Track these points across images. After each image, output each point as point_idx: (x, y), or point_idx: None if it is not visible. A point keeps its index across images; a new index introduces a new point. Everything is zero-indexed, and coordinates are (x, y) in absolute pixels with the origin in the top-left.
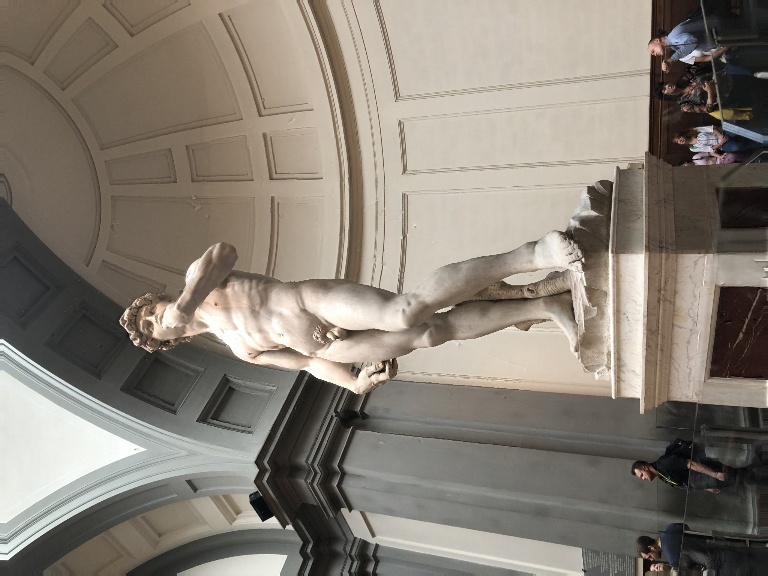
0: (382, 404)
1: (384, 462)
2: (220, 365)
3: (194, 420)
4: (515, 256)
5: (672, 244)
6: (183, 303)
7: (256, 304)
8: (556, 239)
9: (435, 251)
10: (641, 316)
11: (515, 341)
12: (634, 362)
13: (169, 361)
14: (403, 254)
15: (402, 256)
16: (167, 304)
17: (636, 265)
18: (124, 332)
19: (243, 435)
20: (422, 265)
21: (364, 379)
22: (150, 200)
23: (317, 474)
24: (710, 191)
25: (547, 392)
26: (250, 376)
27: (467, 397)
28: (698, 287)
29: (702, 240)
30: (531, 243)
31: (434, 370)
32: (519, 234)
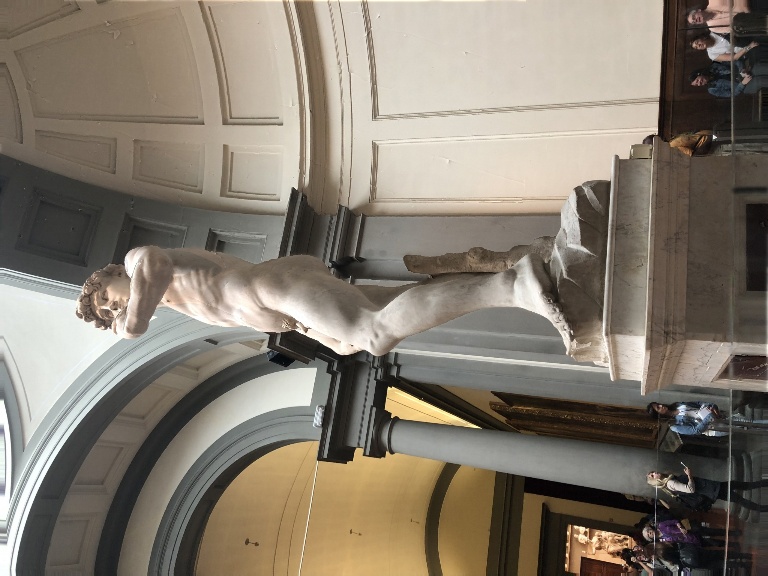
0: (377, 247)
1: None
2: (202, 219)
3: None
4: (491, 292)
5: (681, 322)
6: (131, 326)
7: (211, 301)
8: (538, 294)
9: (408, 46)
10: (642, 356)
11: (510, 151)
12: (634, 369)
13: (149, 226)
14: (371, 55)
15: (370, 58)
16: (117, 287)
17: (636, 339)
18: (91, 208)
19: None
20: (395, 66)
21: (347, 348)
22: (58, 40)
23: None
24: (738, 215)
25: (548, 216)
26: (236, 227)
27: (464, 230)
28: (710, 352)
29: (720, 315)
30: (509, 277)
31: (426, 195)
32: (506, 14)
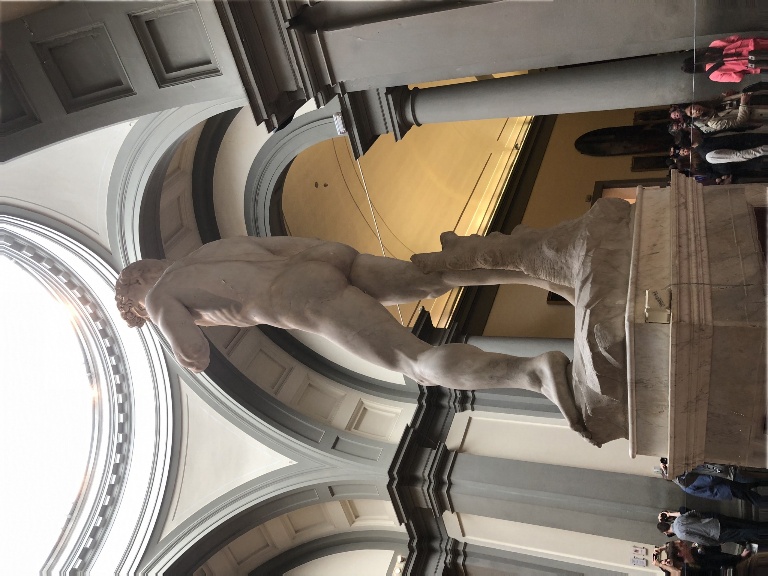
0: None
1: (376, 63)
2: (111, 6)
3: (156, 88)
4: None
5: (700, 454)
6: None
7: None
8: None
9: None
10: None
11: None
12: None
13: (63, 41)
14: None
15: None
16: None
17: None
18: None
19: (214, 79)
20: None
21: None
22: None
23: (317, 96)
24: (761, 380)
25: None
26: (154, 1)
27: None
28: None
29: (736, 450)
30: (535, 384)
31: None
32: None
